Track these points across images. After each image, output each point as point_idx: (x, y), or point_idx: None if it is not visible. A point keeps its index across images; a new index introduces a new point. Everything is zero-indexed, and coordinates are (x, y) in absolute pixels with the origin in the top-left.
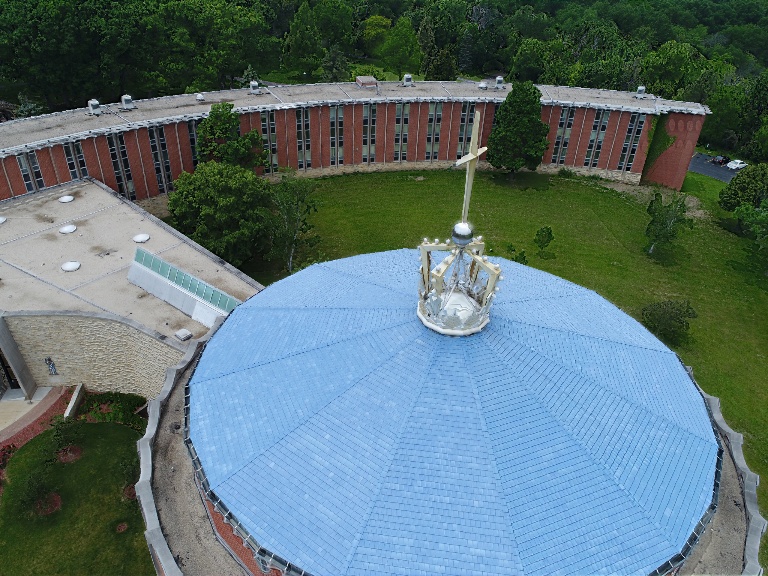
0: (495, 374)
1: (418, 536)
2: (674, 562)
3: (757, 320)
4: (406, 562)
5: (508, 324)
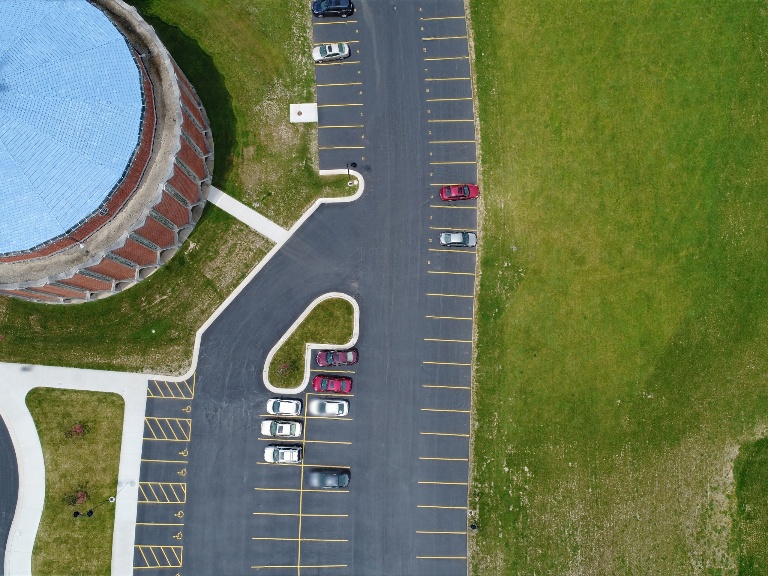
0: (6, 125)
1: (8, 222)
2: (120, 182)
3: None
4: (8, 234)
5: (2, 83)
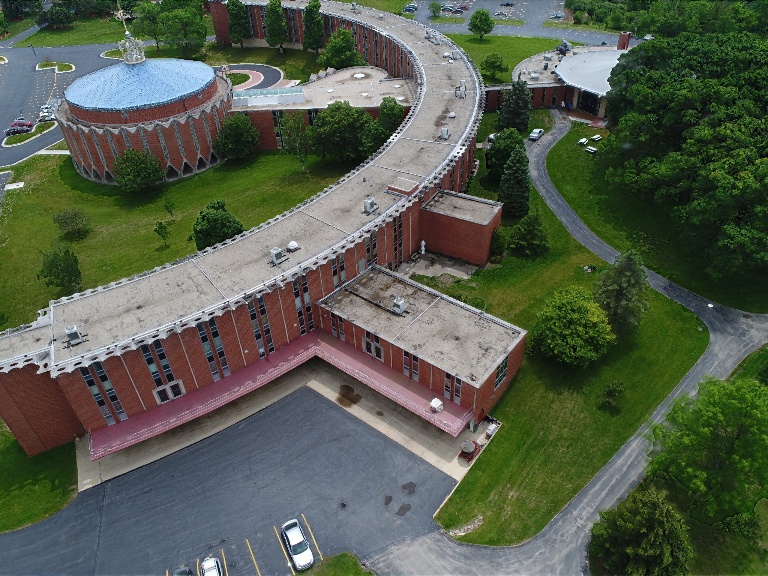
0: None
1: None
2: None
3: (5, 274)
4: None
5: None
